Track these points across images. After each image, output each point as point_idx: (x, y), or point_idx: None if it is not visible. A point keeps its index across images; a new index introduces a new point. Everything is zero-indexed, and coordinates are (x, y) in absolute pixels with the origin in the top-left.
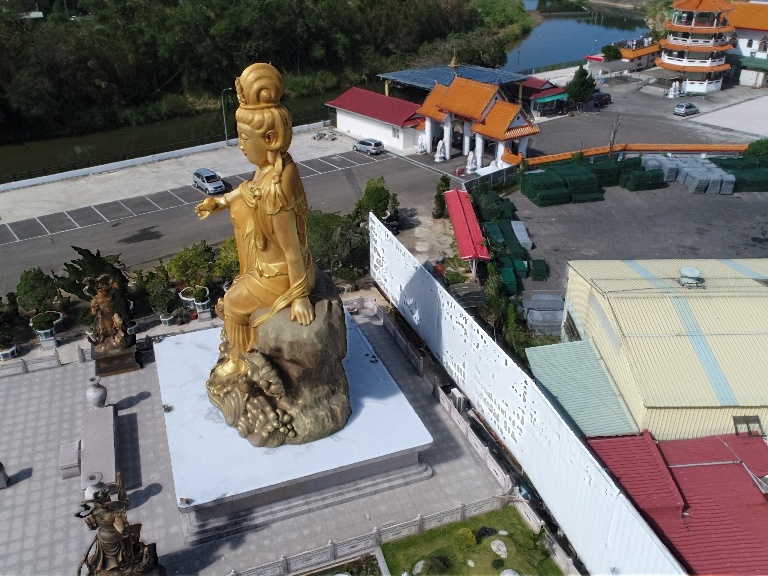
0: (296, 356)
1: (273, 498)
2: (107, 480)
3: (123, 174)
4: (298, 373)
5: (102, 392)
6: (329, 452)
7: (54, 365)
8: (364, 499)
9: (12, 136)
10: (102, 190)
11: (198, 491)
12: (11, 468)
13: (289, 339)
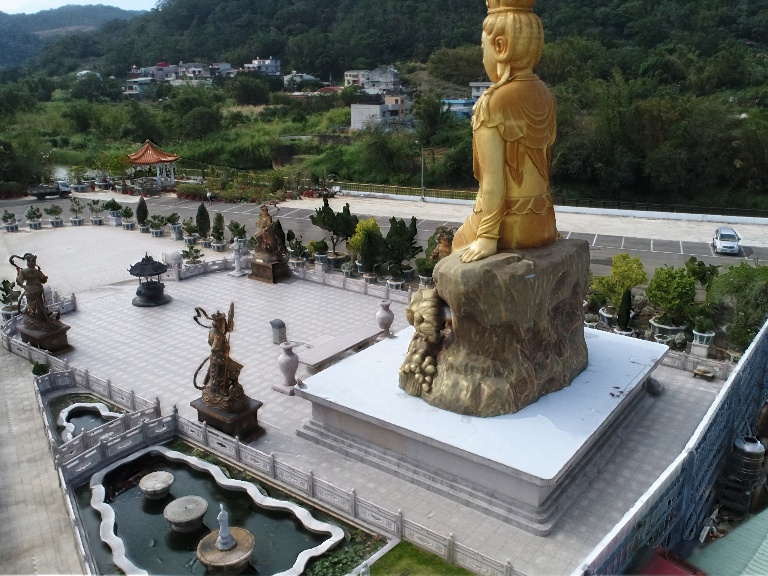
0: (444, 293)
1: (375, 438)
2: (309, 361)
3: (658, 222)
4: (455, 323)
5: (386, 315)
6: (441, 423)
7: (406, 302)
8: (451, 501)
9: (638, 199)
10: (622, 227)
11: (319, 385)
12: (297, 338)
13: (441, 270)
